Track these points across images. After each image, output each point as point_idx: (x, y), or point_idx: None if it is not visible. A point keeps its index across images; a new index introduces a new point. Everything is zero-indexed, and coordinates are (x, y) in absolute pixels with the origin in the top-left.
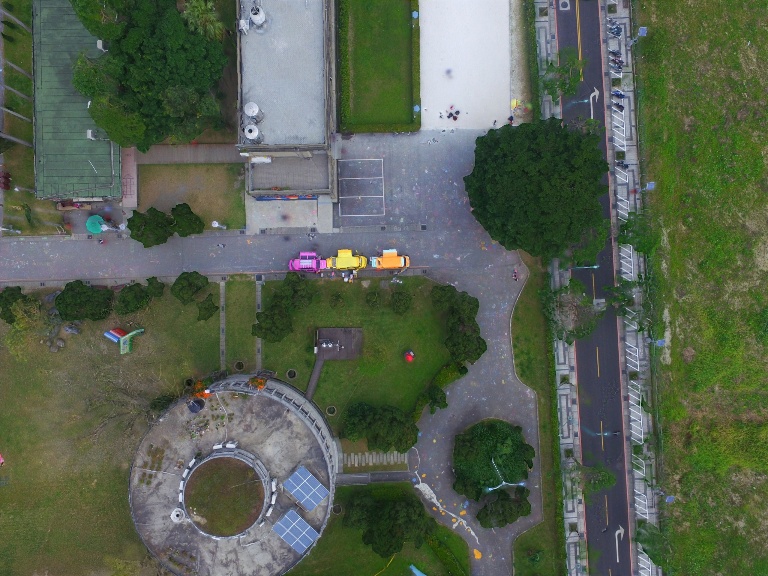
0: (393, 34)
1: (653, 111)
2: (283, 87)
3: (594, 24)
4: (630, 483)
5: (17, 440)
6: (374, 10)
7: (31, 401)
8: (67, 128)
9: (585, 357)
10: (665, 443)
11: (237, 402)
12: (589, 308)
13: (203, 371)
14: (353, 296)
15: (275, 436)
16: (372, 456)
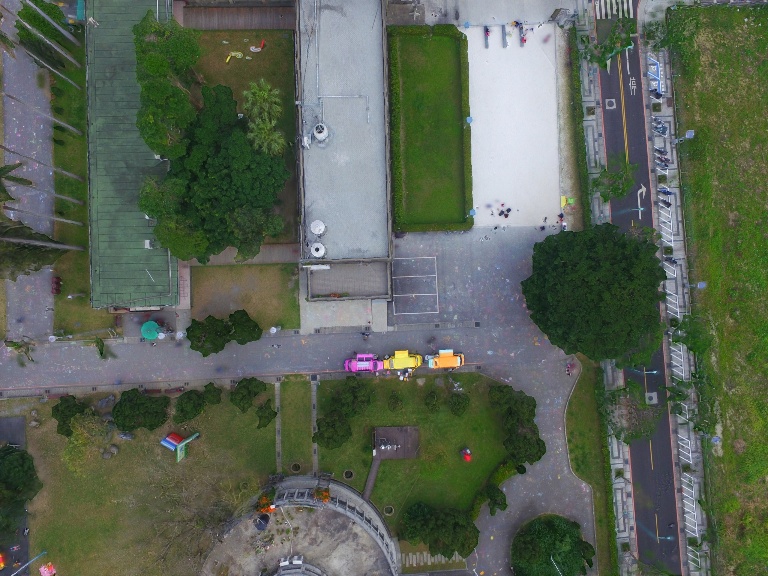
0: (444, 133)
1: (699, 207)
2: (346, 200)
3: (640, 122)
4: (685, 575)
5: (69, 550)
6: (425, 110)
7: (84, 509)
8: (123, 237)
9: (639, 450)
10: (720, 536)
11: (302, 515)
12: (648, 411)
13: (259, 474)
14: (409, 394)
15: (341, 549)
16: (430, 555)
